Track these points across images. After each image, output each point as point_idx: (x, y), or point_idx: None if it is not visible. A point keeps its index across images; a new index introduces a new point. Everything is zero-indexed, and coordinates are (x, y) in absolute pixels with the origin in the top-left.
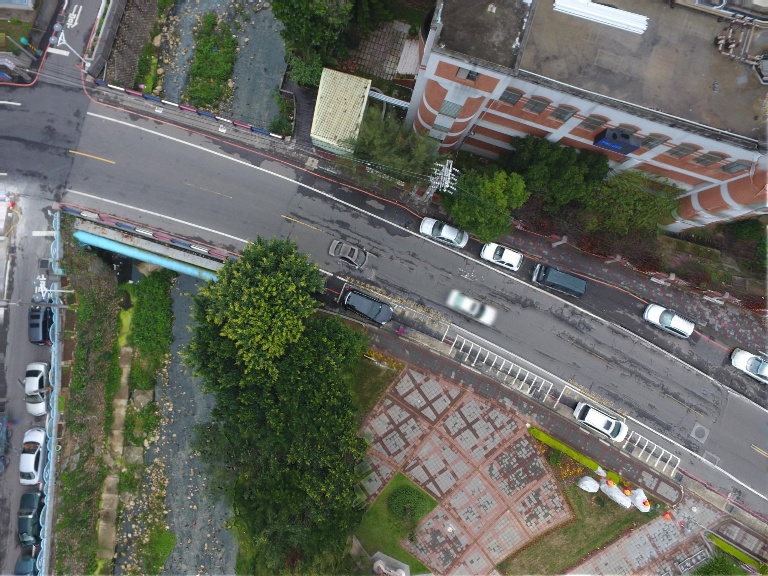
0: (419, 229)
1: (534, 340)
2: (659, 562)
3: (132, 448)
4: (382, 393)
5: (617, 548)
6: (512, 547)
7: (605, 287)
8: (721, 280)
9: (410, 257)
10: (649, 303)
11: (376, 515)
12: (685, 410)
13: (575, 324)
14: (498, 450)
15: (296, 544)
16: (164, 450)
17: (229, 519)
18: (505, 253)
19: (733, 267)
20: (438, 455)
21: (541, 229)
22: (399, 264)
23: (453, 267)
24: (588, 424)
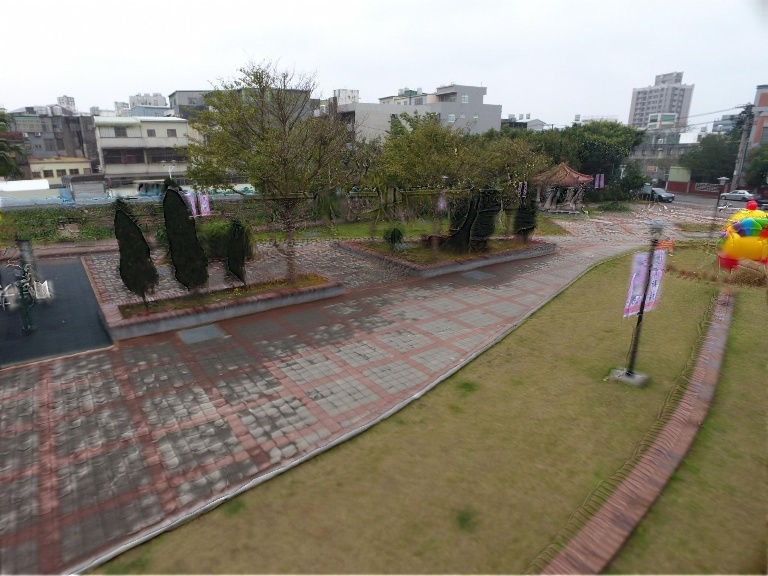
0: None
1: None
2: None
3: None
4: (640, 211)
5: None
6: None
7: None
8: None
9: None
10: None
11: None
12: None
13: None
14: None
15: None
16: None
17: None
18: None
19: None
20: None
21: None
22: None
23: None
24: None
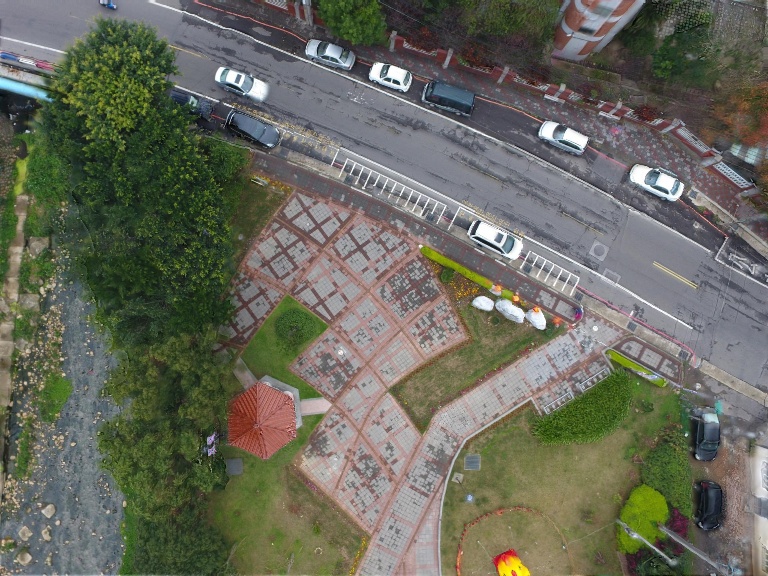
0: (305, 51)
1: (426, 162)
2: (559, 383)
3: (27, 295)
4: (270, 217)
5: (515, 369)
6: (405, 369)
7: (499, 107)
8: (617, 96)
9: (298, 82)
10: (544, 121)
11: (264, 338)
12: (583, 228)
13: (468, 145)
14: (390, 272)
15: (157, 333)
16: (61, 297)
17: (126, 365)
18: (391, 69)
19: (633, 88)
20: (328, 277)
21: (423, 38)
22: (287, 89)
23: (342, 91)
24: (479, 238)
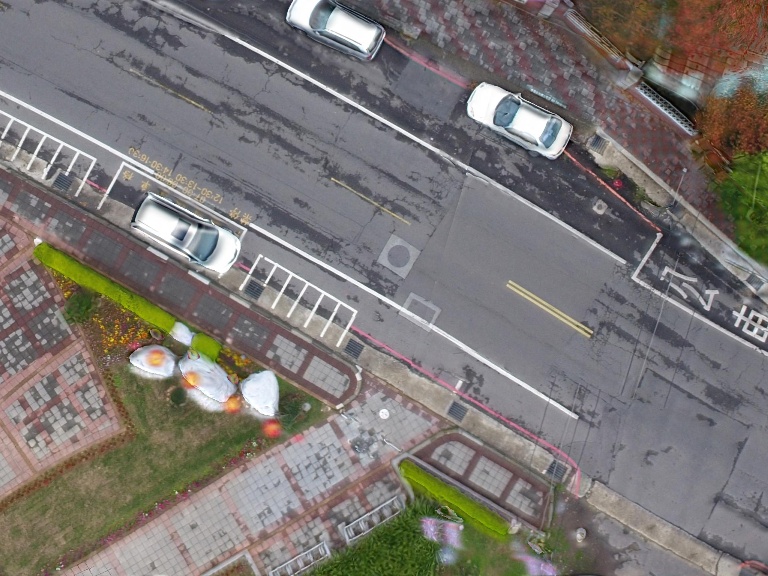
0: None
1: (58, 69)
2: (306, 522)
3: None
4: None
5: (218, 493)
6: None
7: None
8: None
9: None
10: None
11: None
12: (370, 211)
13: (145, 36)
14: None
15: None
16: None
17: None
18: None
19: None
20: None
21: None
22: None
23: None
24: (144, 229)
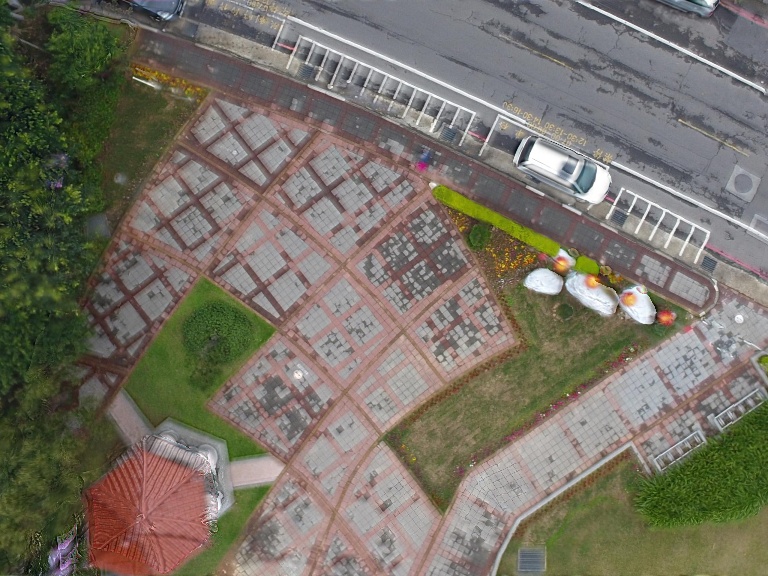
0: None
1: (438, 38)
2: (680, 415)
3: None
4: (167, 141)
5: (603, 394)
6: (412, 400)
7: None
8: None
9: None
10: None
11: (164, 354)
12: (715, 146)
13: (511, 6)
14: (380, 231)
15: None
16: None
17: None
18: None
19: None
20: (272, 244)
21: None
22: None
23: None
24: (536, 167)
